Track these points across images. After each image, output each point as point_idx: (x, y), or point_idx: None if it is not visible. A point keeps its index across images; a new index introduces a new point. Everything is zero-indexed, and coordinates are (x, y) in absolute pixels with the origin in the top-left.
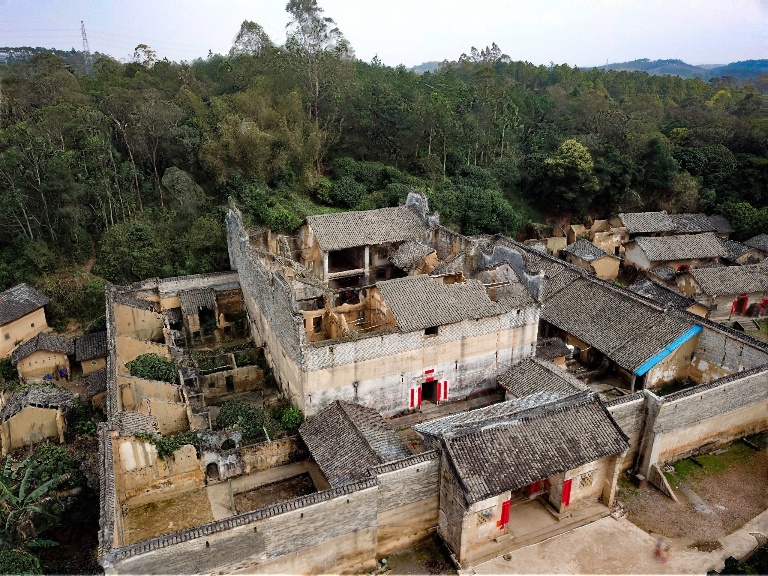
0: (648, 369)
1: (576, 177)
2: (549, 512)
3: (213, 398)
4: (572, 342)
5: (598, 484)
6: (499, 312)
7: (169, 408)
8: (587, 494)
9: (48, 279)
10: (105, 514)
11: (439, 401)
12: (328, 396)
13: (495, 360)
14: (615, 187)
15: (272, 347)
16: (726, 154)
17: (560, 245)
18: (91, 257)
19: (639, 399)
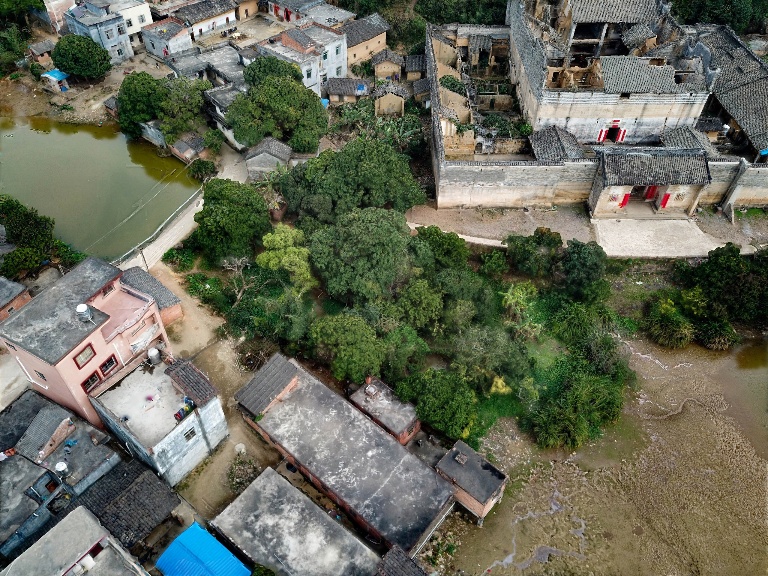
0: None
1: None
2: (652, 209)
3: (481, 110)
4: (732, 124)
5: (687, 202)
6: (676, 92)
7: (461, 109)
8: (678, 205)
9: (389, 11)
10: (442, 147)
11: (617, 141)
12: (550, 122)
13: (664, 123)
14: None
15: (523, 86)
16: None
17: None
18: None
19: (735, 162)
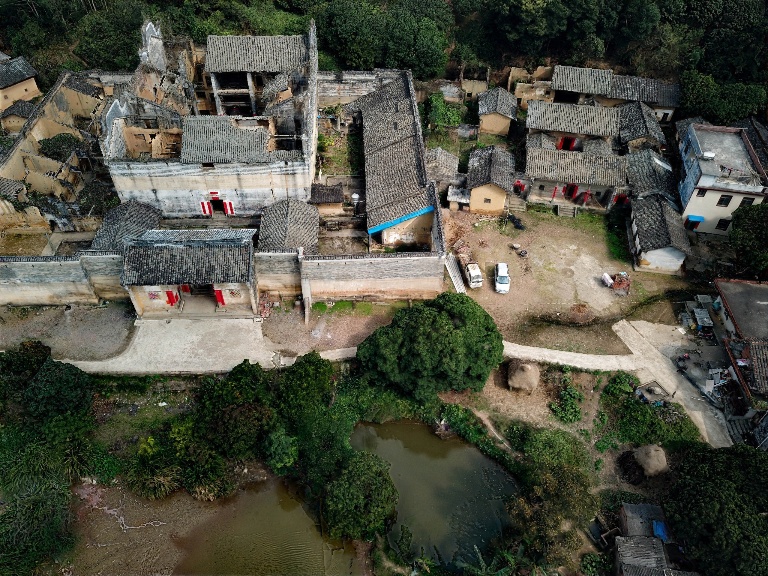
0: (377, 230)
1: (520, 18)
2: (216, 305)
3: (102, 174)
4: None
5: (247, 298)
6: (264, 161)
7: (44, 179)
8: (239, 302)
9: (41, 54)
10: None
11: (228, 214)
12: (135, 195)
13: (272, 195)
14: (574, 32)
15: None
16: (748, 6)
17: (479, 89)
18: (78, 37)
19: (292, 253)
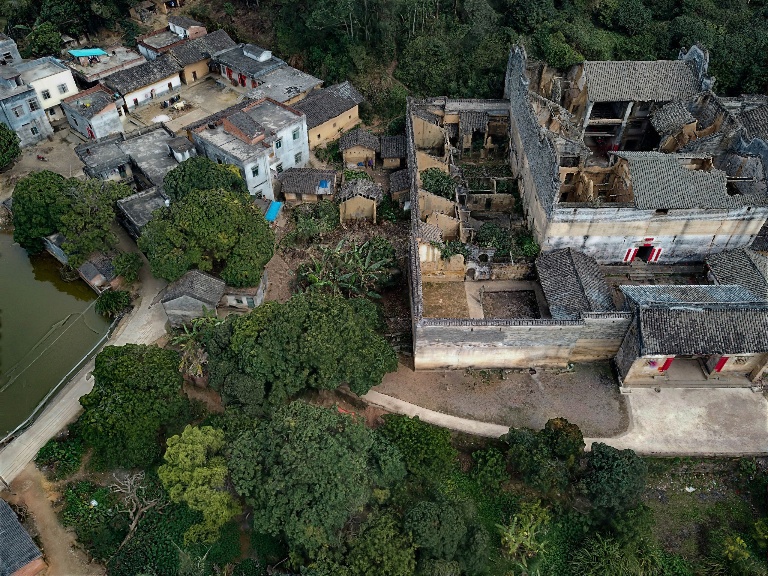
0: None
1: None
2: (702, 371)
3: (474, 212)
4: None
5: (750, 365)
6: (730, 207)
7: (448, 221)
8: (738, 369)
9: (362, 78)
10: (418, 297)
11: (649, 261)
12: (562, 241)
13: (711, 241)
14: None
15: (527, 184)
16: None
17: None
18: (393, 60)
19: None
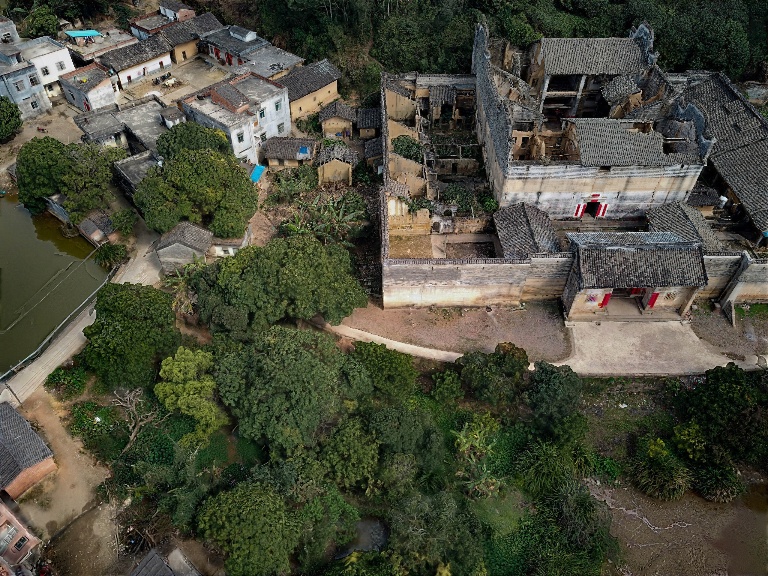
0: None
1: None
2: (638, 308)
3: (442, 175)
4: (730, 194)
5: (679, 301)
6: (665, 164)
7: (416, 181)
8: (669, 305)
9: (341, 56)
10: (385, 240)
11: (597, 217)
12: (518, 197)
13: (651, 197)
14: None
15: (489, 149)
16: None
17: None
18: (370, 39)
19: (736, 256)
